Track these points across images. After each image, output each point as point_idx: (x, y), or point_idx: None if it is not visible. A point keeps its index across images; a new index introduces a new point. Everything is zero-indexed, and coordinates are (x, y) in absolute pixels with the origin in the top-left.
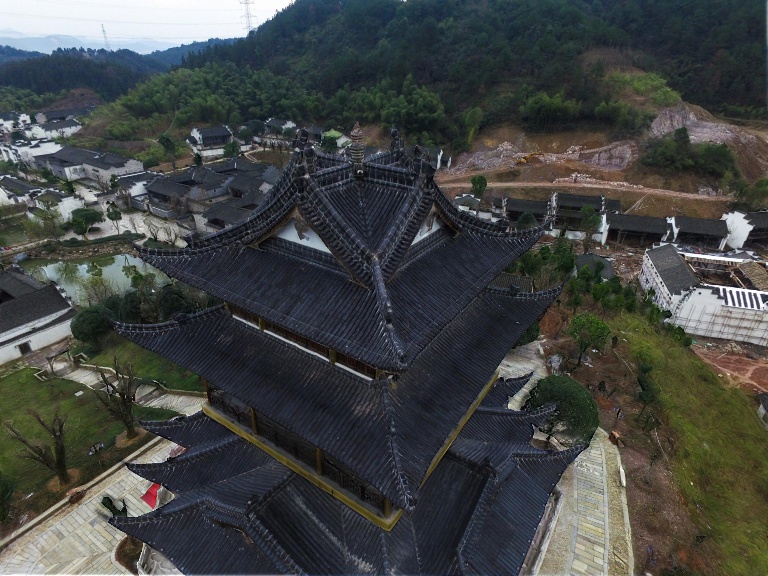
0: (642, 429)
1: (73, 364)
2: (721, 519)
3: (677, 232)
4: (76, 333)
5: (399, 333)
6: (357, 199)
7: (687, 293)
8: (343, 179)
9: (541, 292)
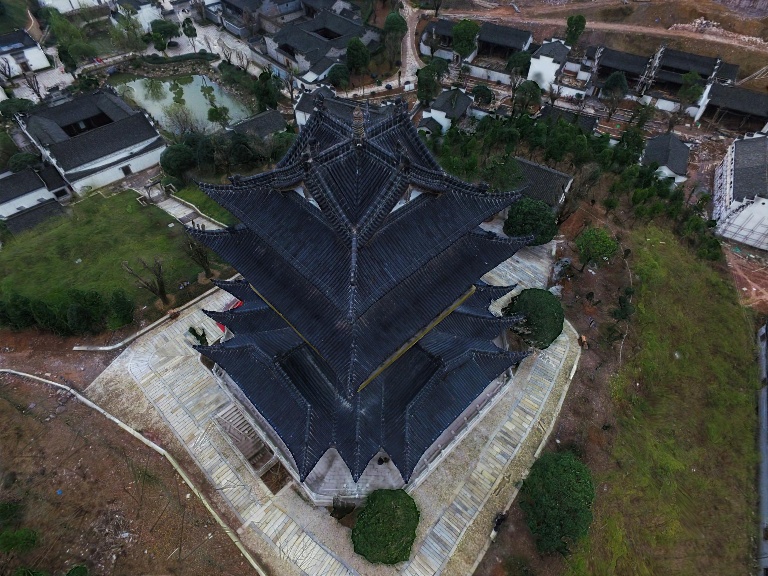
0: (607, 339)
1: (165, 193)
2: (653, 413)
3: None
4: (165, 168)
5: (362, 289)
6: (355, 168)
7: (743, 204)
8: (344, 152)
9: (515, 238)
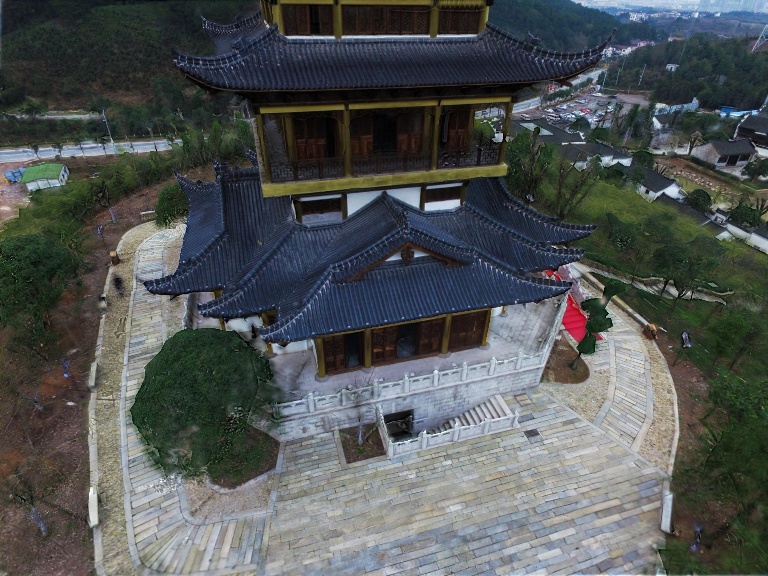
0: None
1: None
2: None
3: None
4: None
5: None
6: None
7: None
8: None
9: None
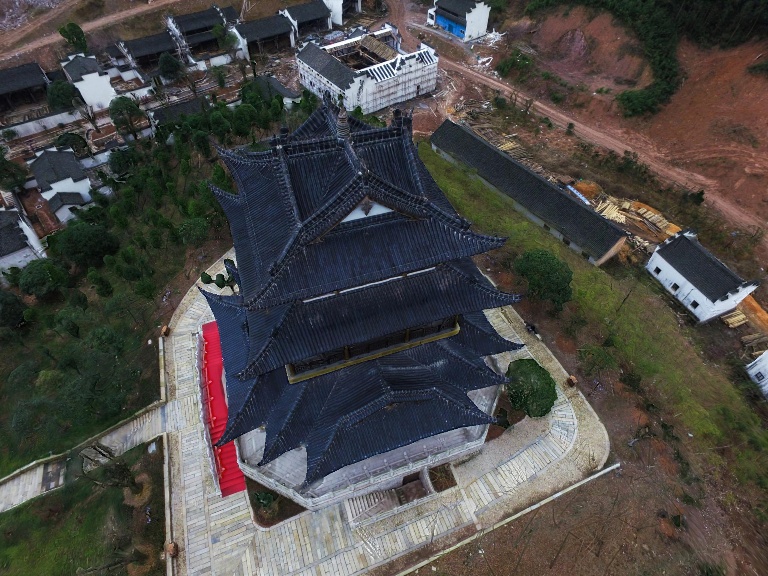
0: None
1: None
2: None
3: (296, 24)
4: None
5: None
6: None
7: (360, 86)
8: None
9: None
